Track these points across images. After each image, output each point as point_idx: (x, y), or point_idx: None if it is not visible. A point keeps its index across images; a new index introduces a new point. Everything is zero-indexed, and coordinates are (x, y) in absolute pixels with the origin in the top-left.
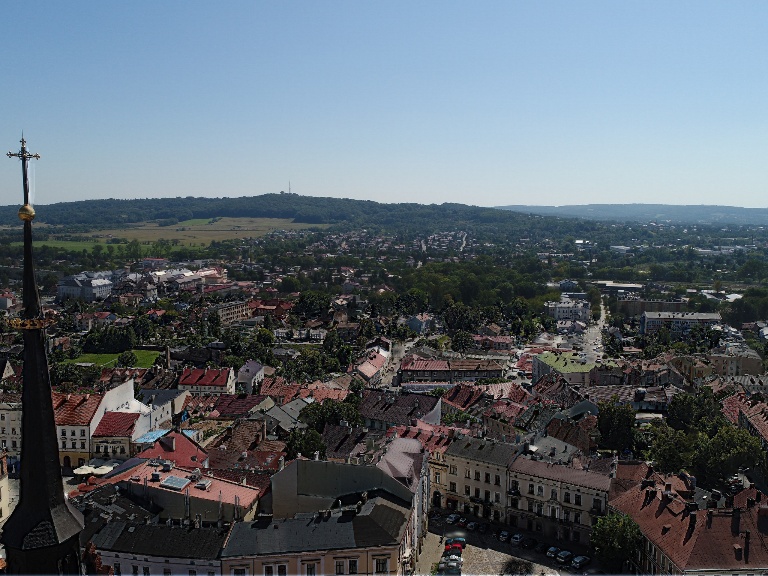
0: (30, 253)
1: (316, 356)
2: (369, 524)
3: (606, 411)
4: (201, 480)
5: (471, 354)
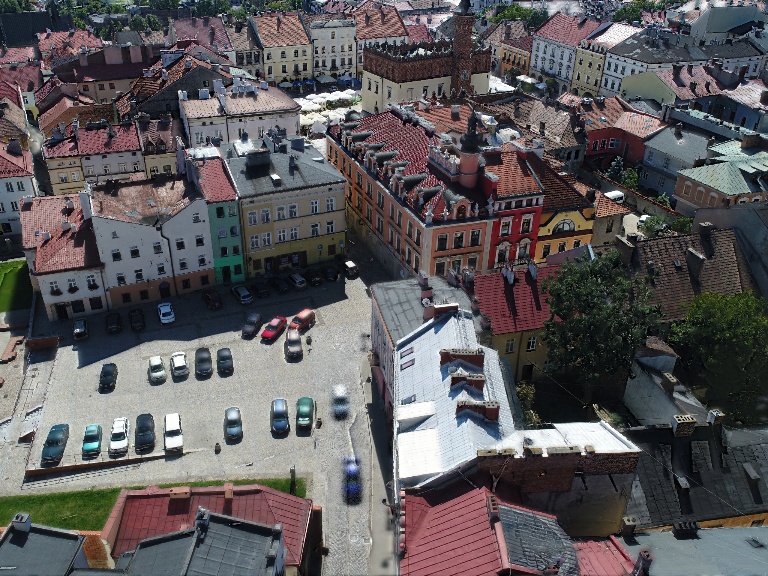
0: None
1: (286, 8)
2: None
3: (643, 7)
4: None
5: None
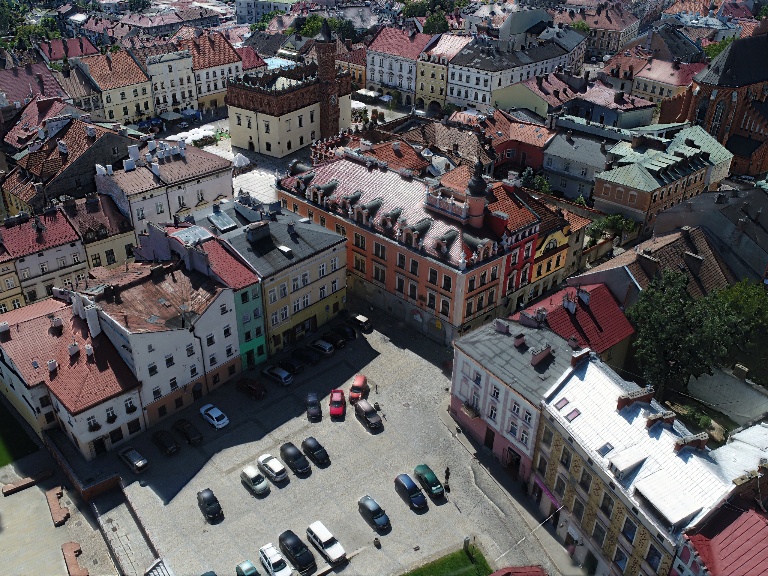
0: None
1: (43, 30)
2: (575, 29)
3: (416, 6)
4: None
5: None
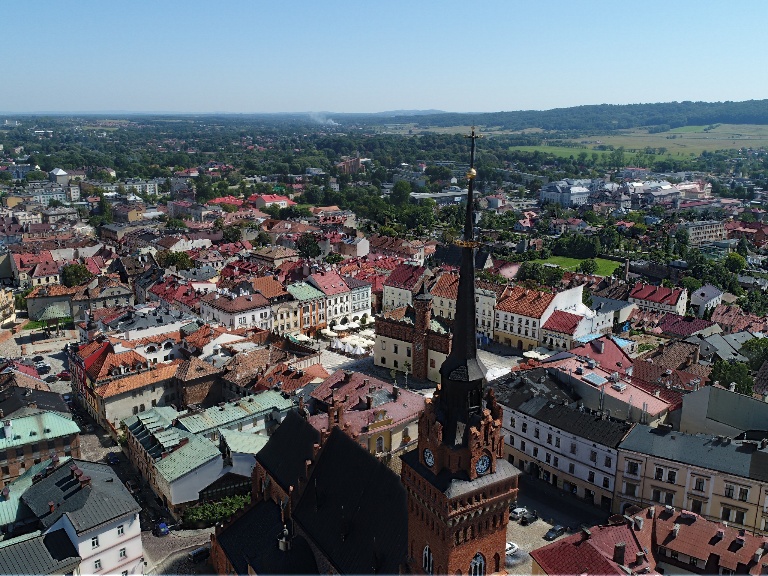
0: (470, 199)
1: None
2: None
3: None
4: (618, 382)
5: None
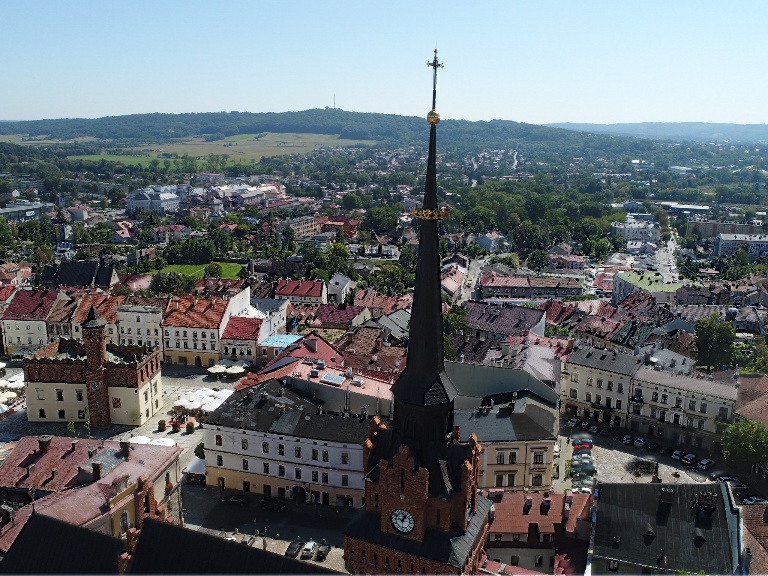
0: (434, 152)
1: (396, 271)
2: (526, 420)
3: (706, 328)
4: (355, 378)
5: (546, 272)
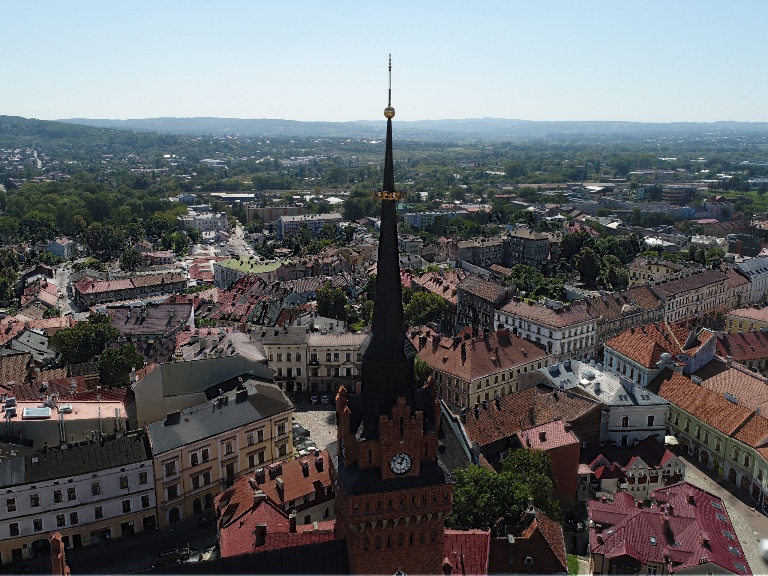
0: None
1: None
2: (263, 399)
3: (325, 296)
4: (60, 405)
5: (138, 271)
